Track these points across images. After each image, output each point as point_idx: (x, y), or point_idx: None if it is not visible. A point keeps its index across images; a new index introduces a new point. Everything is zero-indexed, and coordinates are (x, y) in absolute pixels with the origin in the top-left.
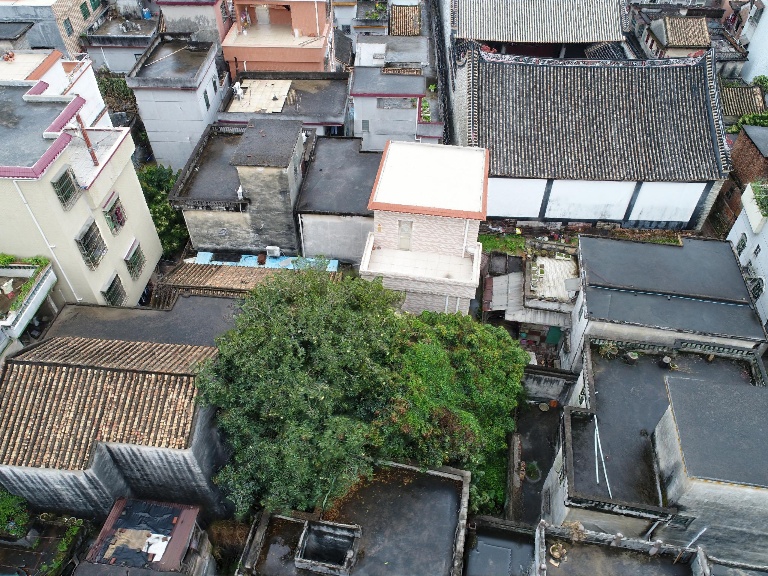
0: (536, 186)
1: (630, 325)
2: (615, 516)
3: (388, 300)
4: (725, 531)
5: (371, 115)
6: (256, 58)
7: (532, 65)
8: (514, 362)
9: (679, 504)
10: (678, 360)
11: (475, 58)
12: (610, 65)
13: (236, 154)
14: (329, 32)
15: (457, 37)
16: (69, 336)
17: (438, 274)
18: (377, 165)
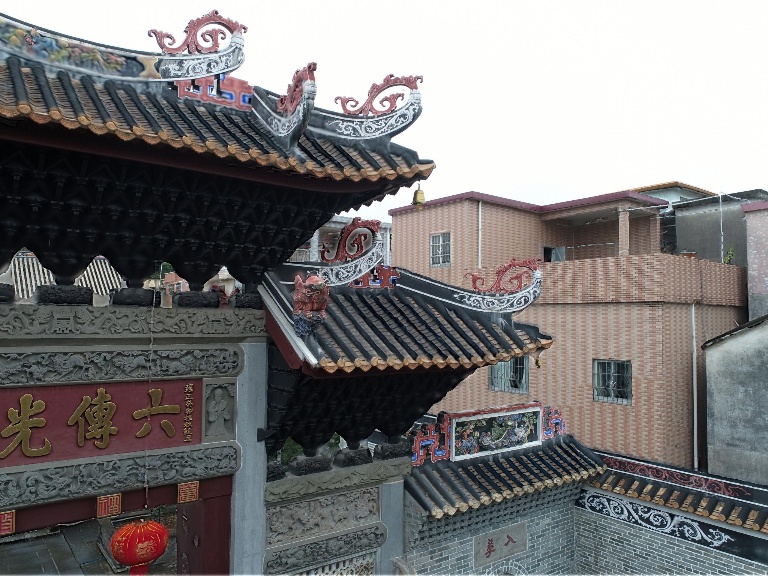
0: None
1: None
2: None
3: None
4: None
5: None
6: None
7: None
8: None
9: None
10: None
11: None
12: None
13: None
14: (181, 281)
15: None
16: None
17: None
18: None
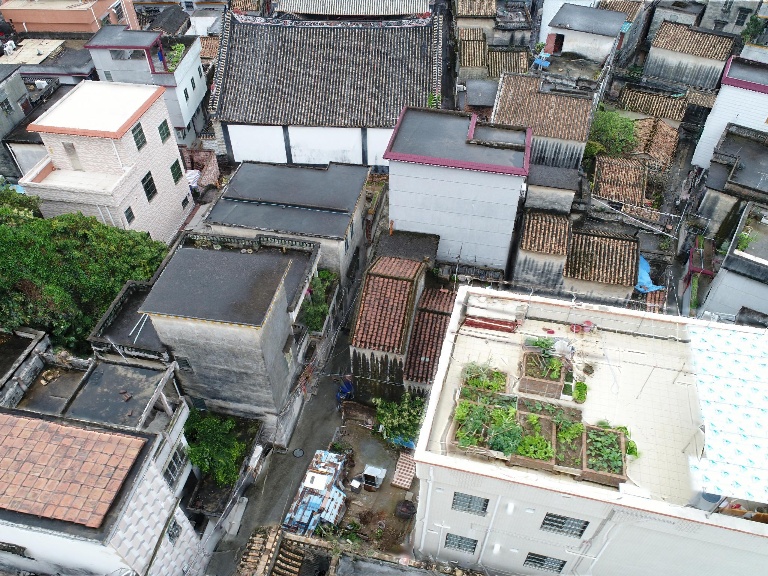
0: (275, 133)
1: (239, 228)
2: (133, 359)
3: (15, 200)
4: (217, 371)
5: (110, 66)
6: (32, 20)
7: (282, 26)
8: (141, 258)
9: (165, 344)
10: (260, 252)
11: (228, 20)
12: (351, 26)
13: None
14: None
15: (277, 10)
16: None
17: (96, 188)
18: None
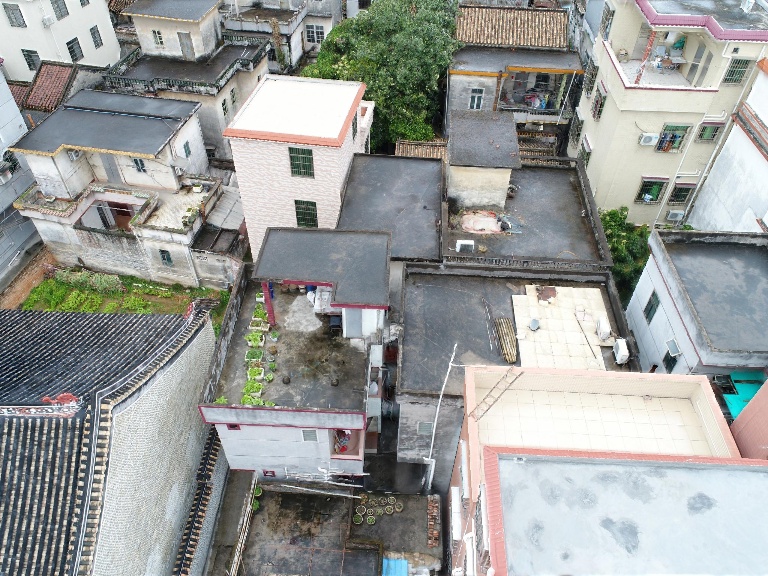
0: None
1: None
2: None
3: None
4: None
5: None
6: None
7: None
8: None
9: None
10: None
11: None
12: None
13: (512, 121)
14: None
15: None
16: (563, 57)
17: None
18: (353, 212)
